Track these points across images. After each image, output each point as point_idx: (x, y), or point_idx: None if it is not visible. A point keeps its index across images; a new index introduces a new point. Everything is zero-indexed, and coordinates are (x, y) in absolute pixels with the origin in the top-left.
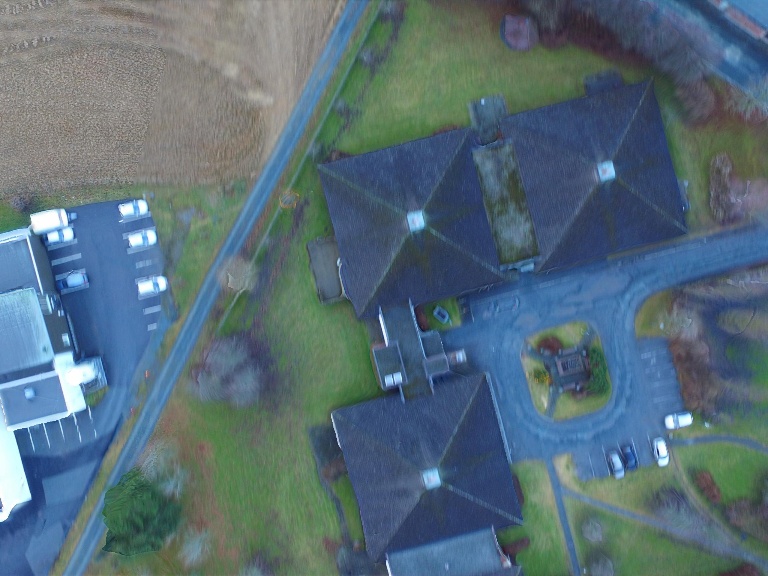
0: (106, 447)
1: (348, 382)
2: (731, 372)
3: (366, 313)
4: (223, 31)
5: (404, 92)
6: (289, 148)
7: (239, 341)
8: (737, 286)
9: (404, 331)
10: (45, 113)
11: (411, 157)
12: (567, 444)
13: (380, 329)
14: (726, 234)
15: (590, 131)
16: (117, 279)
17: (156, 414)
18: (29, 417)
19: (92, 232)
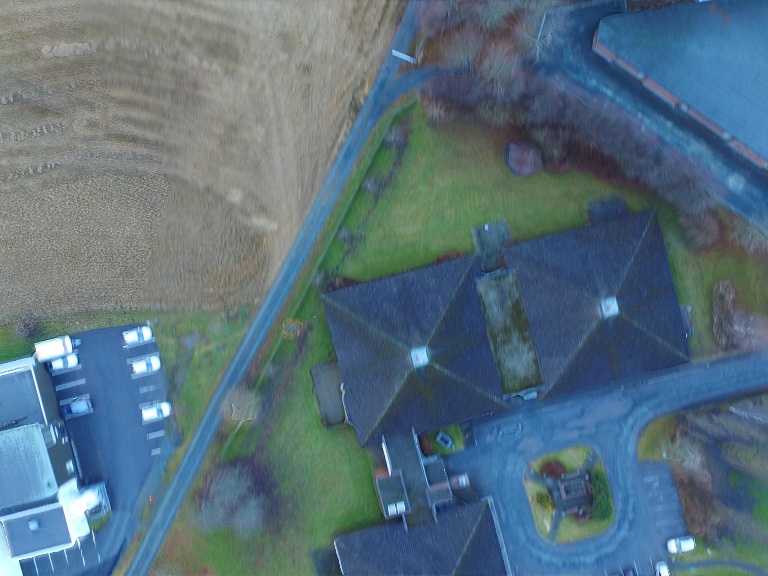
0: (110, 571)
1: (351, 506)
2: (734, 499)
3: (369, 442)
4: (227, 157)
5: (408, 217)
6: (293, 274)
7: (242, 468)
8: (740, 415)
9: (407, 460)
10: (50, 239)
11: (415, 288)
12: (569, 567)
13: (383, 457)
14: (729, 359)
15: (593, 264)
16: (121, 404)
17: (159, 538)
18: (33, 549)
19: (96, 358)
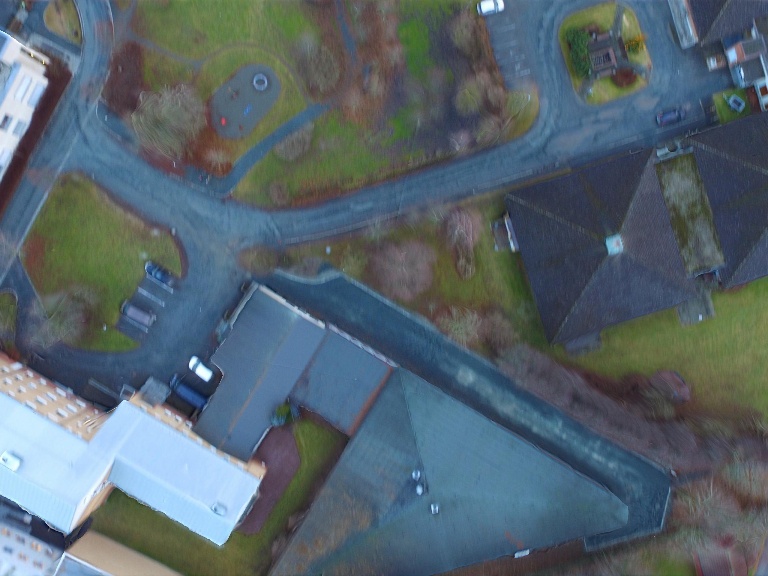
0: None
1: None
2: (449, 56)
3: None
4: None
5: None
6: None
7: None
8: None
9: None
10: None
11: None
12: None
13: None
14: (455, 199)
15: (620, 287)
16: None
17: None
18: None
19: None
